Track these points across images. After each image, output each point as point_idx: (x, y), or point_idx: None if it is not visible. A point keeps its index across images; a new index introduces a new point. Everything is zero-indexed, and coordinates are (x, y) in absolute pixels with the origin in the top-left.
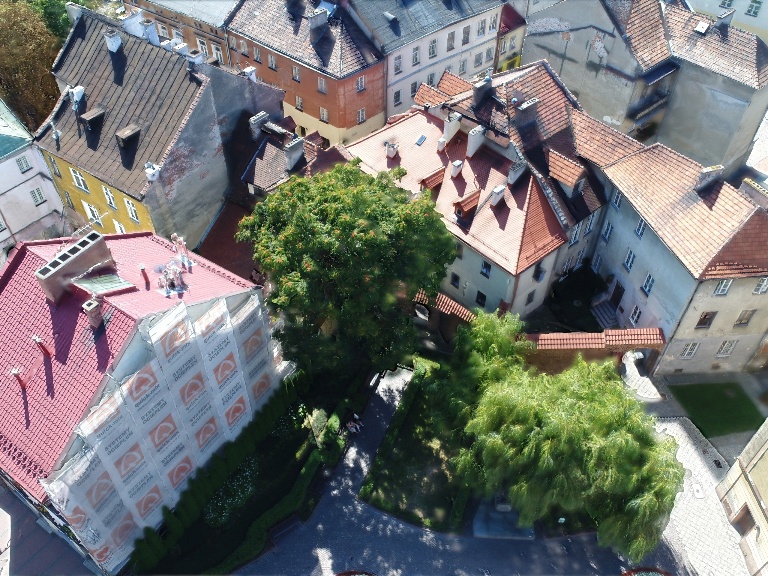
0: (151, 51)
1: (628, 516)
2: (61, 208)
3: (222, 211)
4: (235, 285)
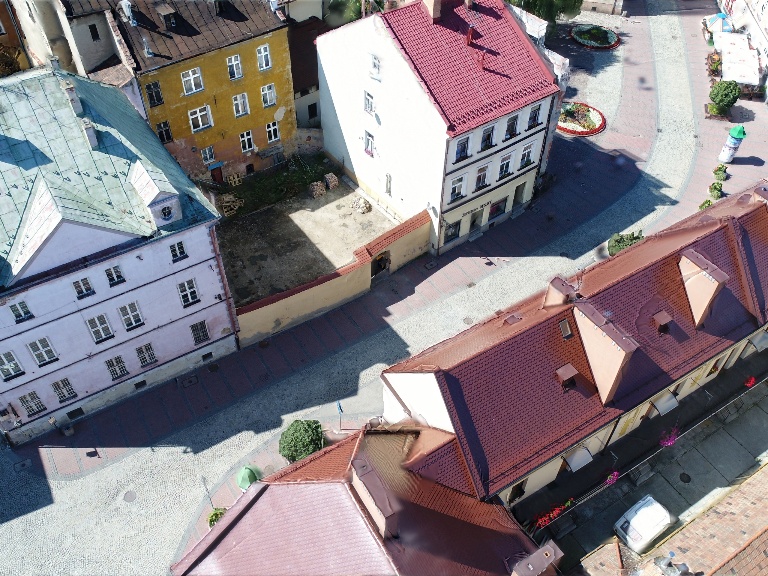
0: None
1: None
2: None
3: None
4: None
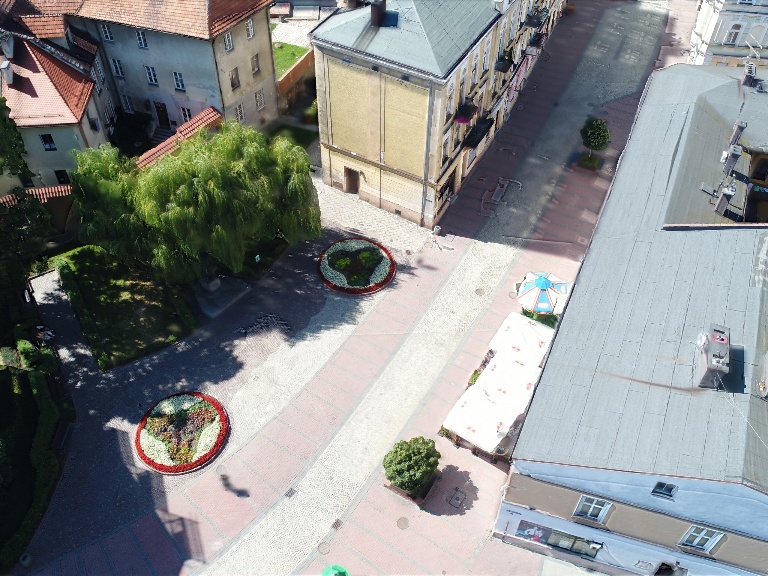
0: None
1: (294, 205)
2: None
3: None
4: None
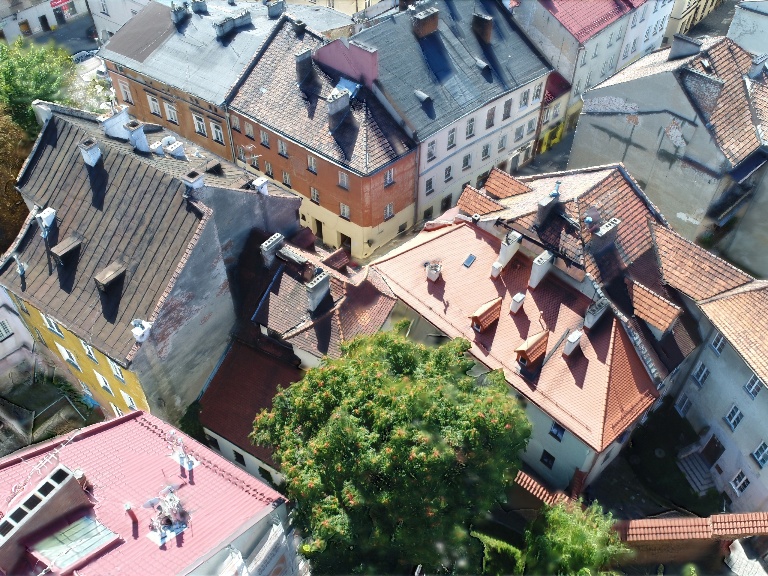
0: (138, 168)
1: None
2: (31, 343)
3: (228, 353)
4: (250, 498)
